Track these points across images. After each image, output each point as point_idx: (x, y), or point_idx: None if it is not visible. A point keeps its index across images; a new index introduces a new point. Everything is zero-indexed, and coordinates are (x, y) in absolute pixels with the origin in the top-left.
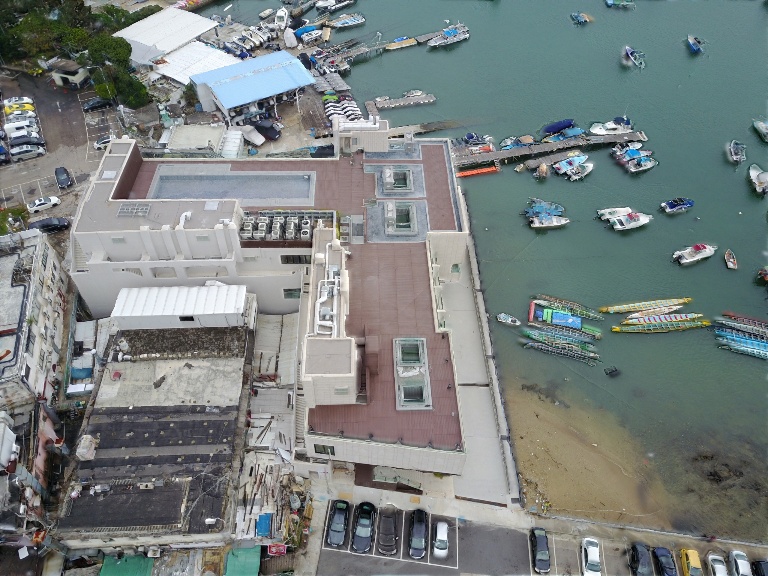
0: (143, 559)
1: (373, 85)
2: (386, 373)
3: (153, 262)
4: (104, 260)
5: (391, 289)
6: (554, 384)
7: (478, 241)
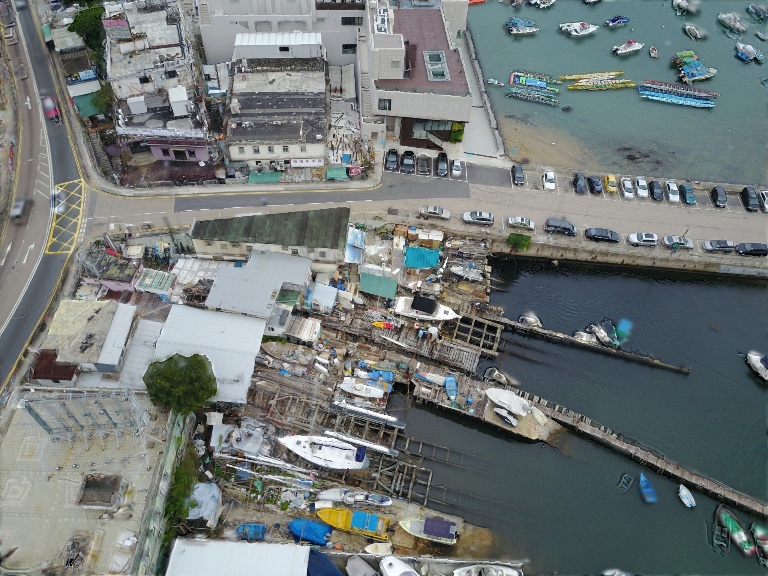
0: (274, 173)
1: None
2: (420, 67)
3: (258, 16)
4: (224, 15)
5: (419, 30)
6: (527, 115)
7: None
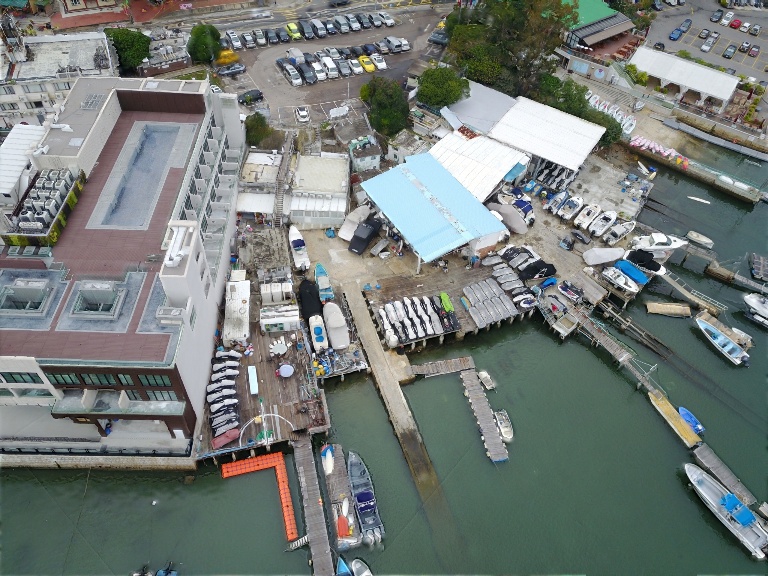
0: None
1: (532, 372)
2: None
3: None
4: None
5: None
6: None
7: (135, 488)
